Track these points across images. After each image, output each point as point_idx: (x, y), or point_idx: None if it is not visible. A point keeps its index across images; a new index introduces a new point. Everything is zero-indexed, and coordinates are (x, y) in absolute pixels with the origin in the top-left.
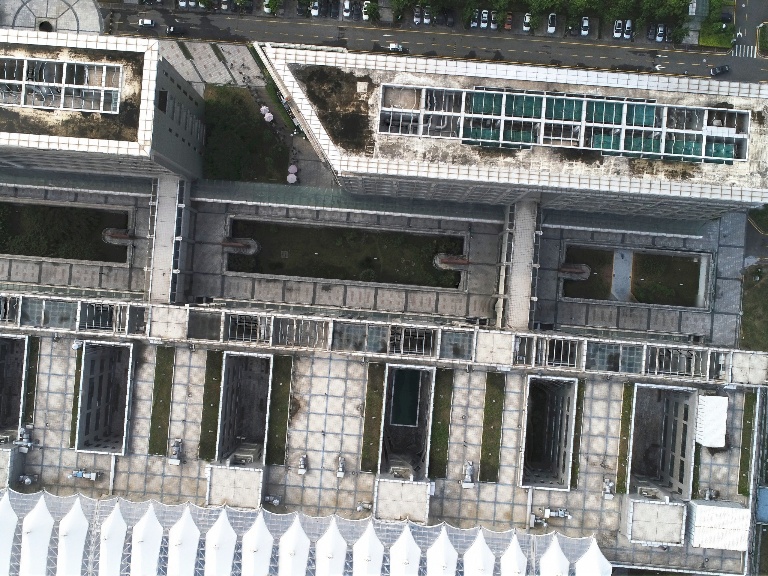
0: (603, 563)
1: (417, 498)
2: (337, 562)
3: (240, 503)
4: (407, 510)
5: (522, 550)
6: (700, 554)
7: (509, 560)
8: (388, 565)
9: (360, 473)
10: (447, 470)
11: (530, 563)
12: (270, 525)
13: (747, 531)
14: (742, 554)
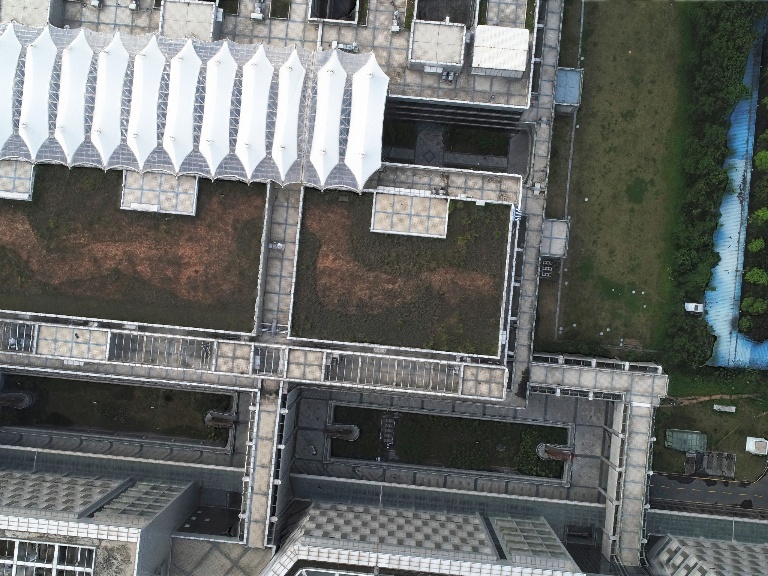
0: (378, 71)
1: (202, 19)
2: (116, 66)
3: (29, 23)
4: (192, 30)
5: (301, 63)
6: (487, 91)
7: (285, 66)
8: (168, 74)
9: (154, 9)
10: (239, 7)
11: (309, 75)
12: (55, 38)
13: (525, 51)
14: (527, 88)
